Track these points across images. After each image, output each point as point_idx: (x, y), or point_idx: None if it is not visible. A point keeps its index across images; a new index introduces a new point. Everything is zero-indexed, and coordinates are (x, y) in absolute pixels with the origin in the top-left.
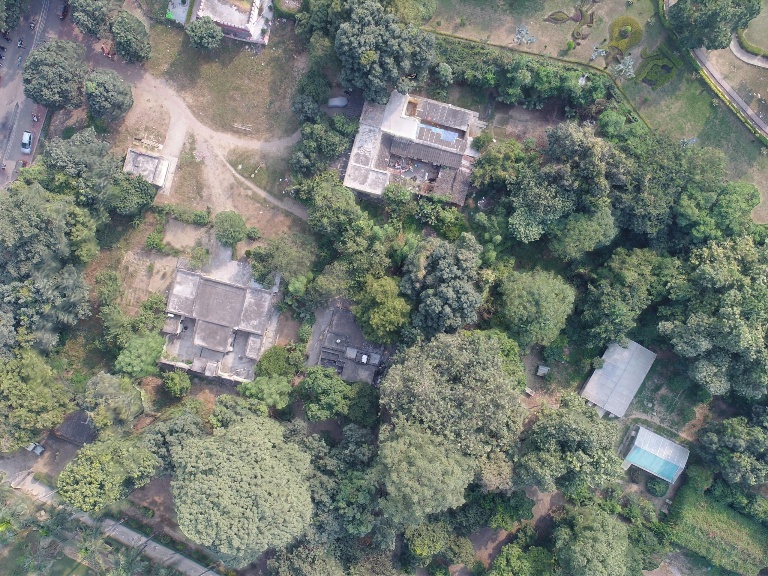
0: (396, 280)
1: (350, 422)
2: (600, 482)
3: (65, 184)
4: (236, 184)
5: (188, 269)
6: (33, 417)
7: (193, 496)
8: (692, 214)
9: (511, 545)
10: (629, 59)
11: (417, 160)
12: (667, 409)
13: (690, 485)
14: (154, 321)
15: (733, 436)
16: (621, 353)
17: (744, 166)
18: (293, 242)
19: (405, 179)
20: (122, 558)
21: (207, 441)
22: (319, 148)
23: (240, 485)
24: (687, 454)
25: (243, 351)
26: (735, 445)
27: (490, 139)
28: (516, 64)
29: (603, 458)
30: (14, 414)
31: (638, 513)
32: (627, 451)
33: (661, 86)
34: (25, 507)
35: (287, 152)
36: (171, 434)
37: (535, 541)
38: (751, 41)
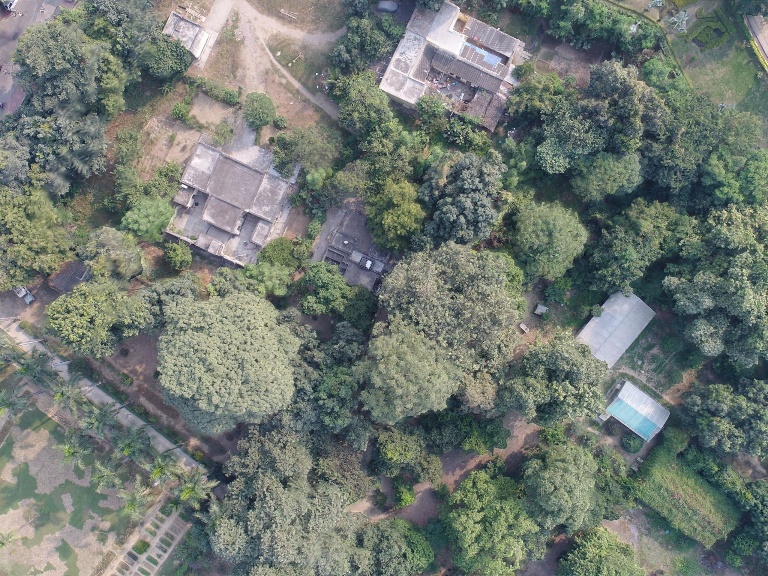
0: (415, 187)
1: (344, 321)
2: (581, 415)
3: (103, 30)
4: (272, 70)
5: (209, 144)
6: (31, 256)
7: (181, 348)
8: (719, 174)
9: (480, 471)
10: (684, 14)
11: (456, 79)
12: (655, 369)
13: (665, 445)
14: (167, 188)
15: (717, 400)
16: (621, 305)
17: None
18: (319, 133)
19: (441, 94)
20: (96, 409)
21: (202, 303)
22: (362, 45)
23: (229, 347)
24: (667, 415)
25: (249, 237)
26: (717, 409)
27: (532, 69)
28: None
29: (588, 392)
30: (13, 248)
31: (609, 464)
32: (609, 402)
33: (710, 49)
34: (8, 342)
35: (328, 47)
36: (167, 294)
37: (503, 473)
38: None
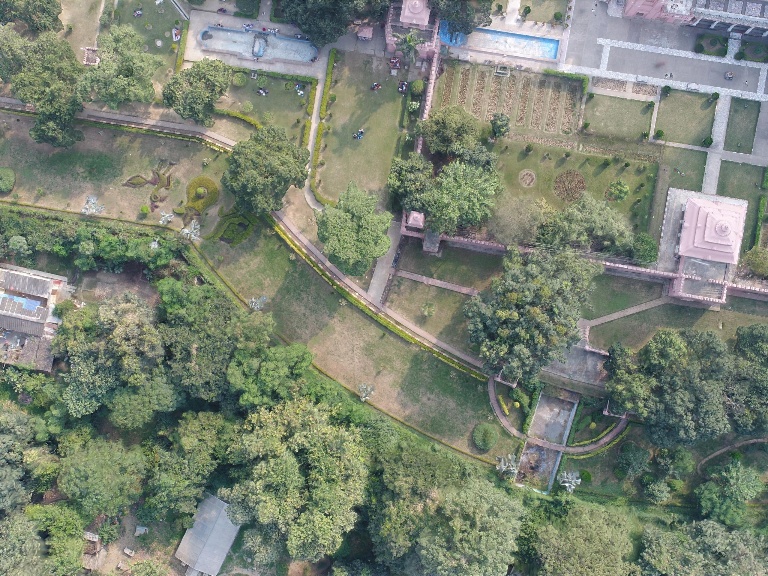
0: None
1: None
2: None
3: None
4: None
5: None
6: None
7: None
8: (235, 382)
9: None
10: (194, 223)
11: None
12: None
13: None
14: None
15: None
16: (209, 512)
17: (325, 318)
18: None
19: None
20: None
21: None
22: None
23: None
24: None
25: None
26: None
27: (70, 306)
28: (79, 236)
29: None
30: None
31: None
32: None
33: (239, 243)
34: None
35: None
36: None
37: None
38: (328, 194)
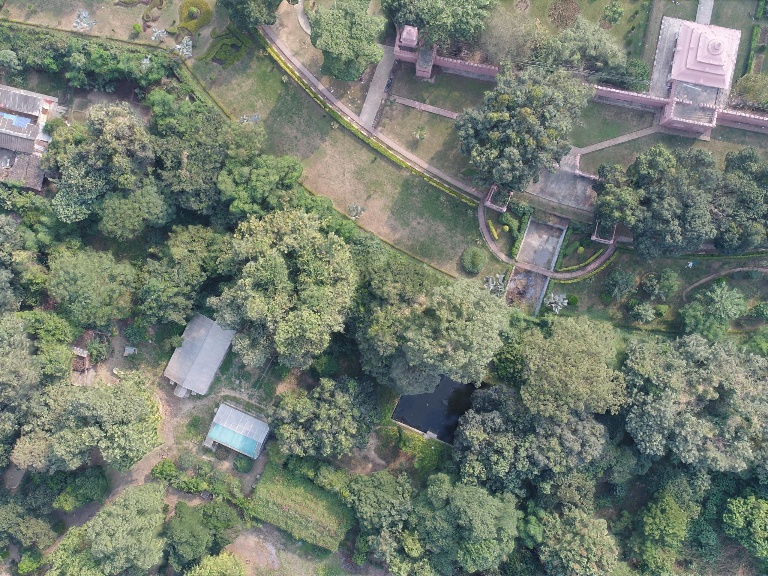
0: None
1: None
2: (114, 456)
3: None
4: None
5: None
6: None
7: None
8: (225, 189)
9: (82, 525)
10: (186, 39)
11: None
12: (254, 385)
13: None
14: None
15: (281, 408)
16: (198, 331)
17: (317, 141)
18: None
19: None
20: None
21: None
22: None
23: None
24: (267, 429)
25: None
26: (280, 417)
27: (60, 123)
28: (70, 48)
29: (117, 432)
30: None
31: (221, 489)
32: (209, 428)
33: (232, 65)
34: None
35: None
36: None
37: None
38: None
